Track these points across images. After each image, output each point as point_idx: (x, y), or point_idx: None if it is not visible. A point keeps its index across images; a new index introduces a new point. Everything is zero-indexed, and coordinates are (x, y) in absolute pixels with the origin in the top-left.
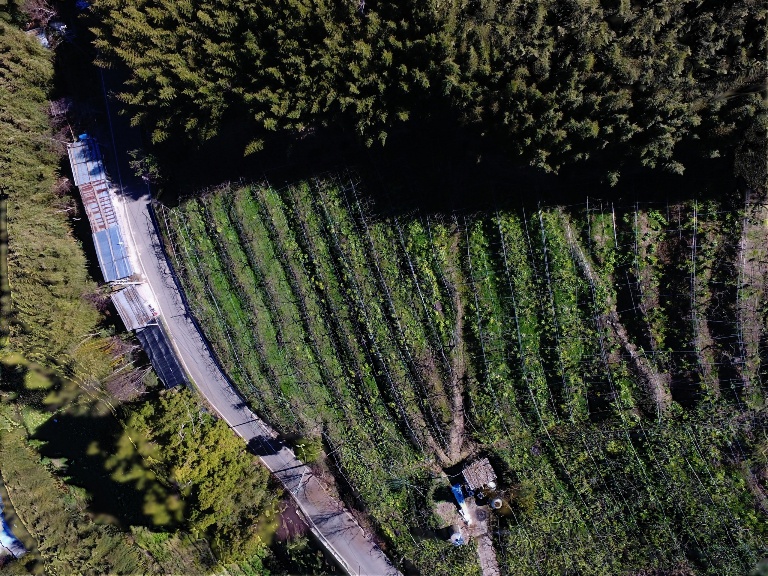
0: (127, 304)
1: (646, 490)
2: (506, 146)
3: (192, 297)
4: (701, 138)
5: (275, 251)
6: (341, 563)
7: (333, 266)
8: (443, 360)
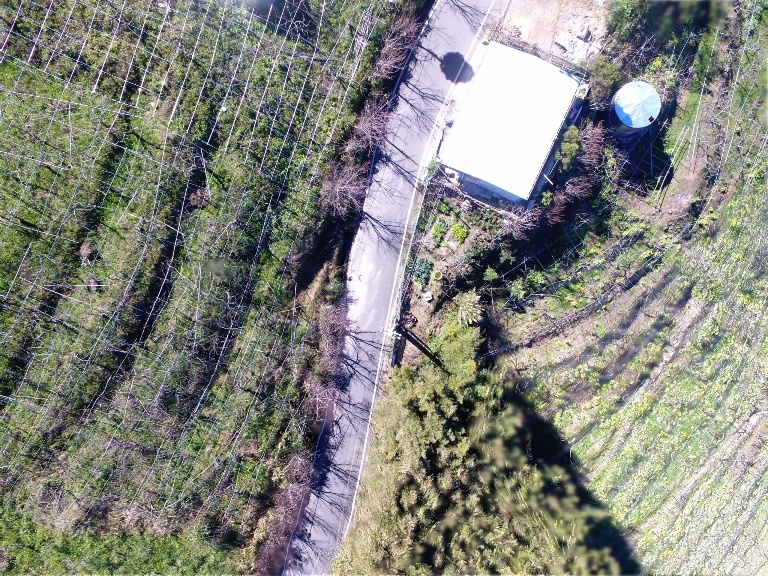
0: None
1: None
2: (581, 574)
3: None
4: (505, 459)
5: None
6: None
7: None
8: None
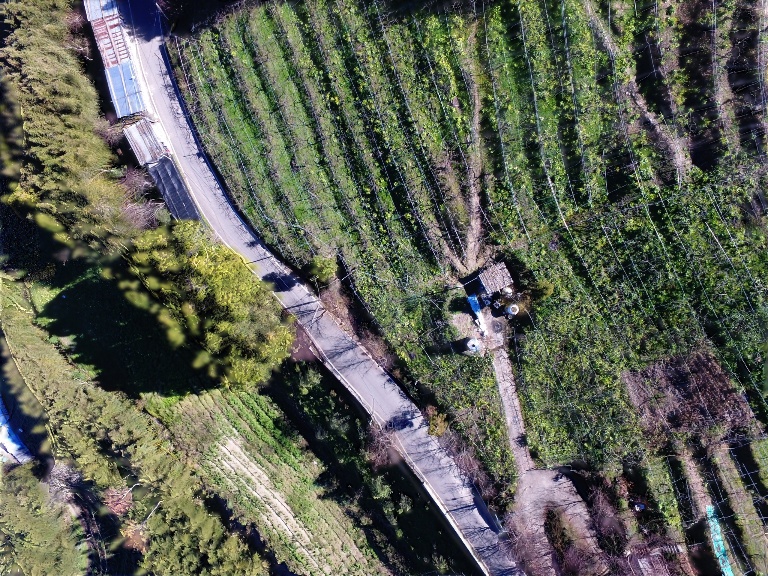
0: (140, 137)
1: (665, 267)
2: None
3: (205, 130)
4: None
5: (290, 71)
6: (355, 396)
7: (349, 79)
8: (460, 157)
